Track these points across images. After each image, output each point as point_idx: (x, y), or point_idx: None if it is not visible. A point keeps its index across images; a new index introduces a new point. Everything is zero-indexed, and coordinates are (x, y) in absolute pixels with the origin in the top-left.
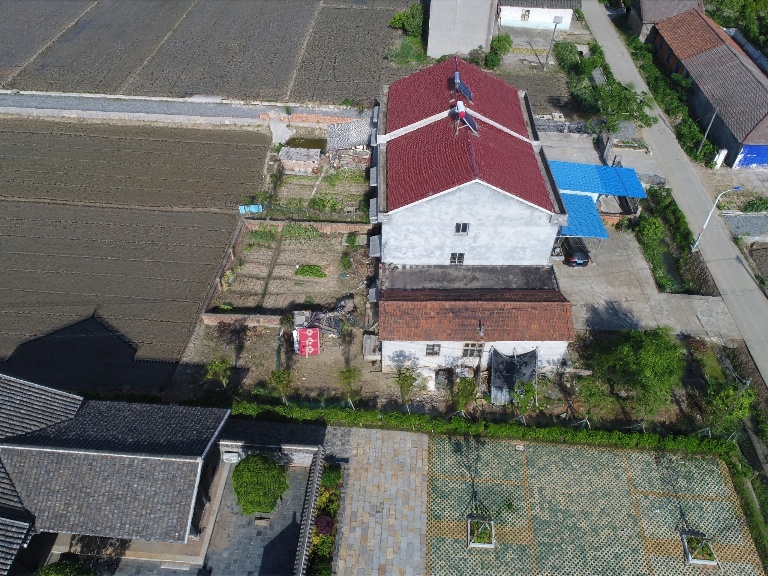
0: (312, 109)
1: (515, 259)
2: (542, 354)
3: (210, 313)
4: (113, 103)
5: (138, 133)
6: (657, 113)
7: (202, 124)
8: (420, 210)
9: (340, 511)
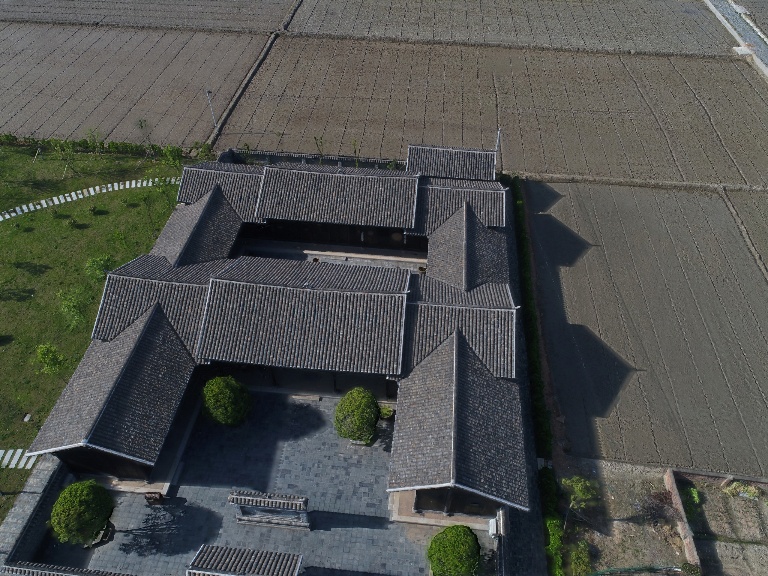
0: None
1: None
2: None
3: None
4: None
5: None
6: None
7: None
8: None
9: None
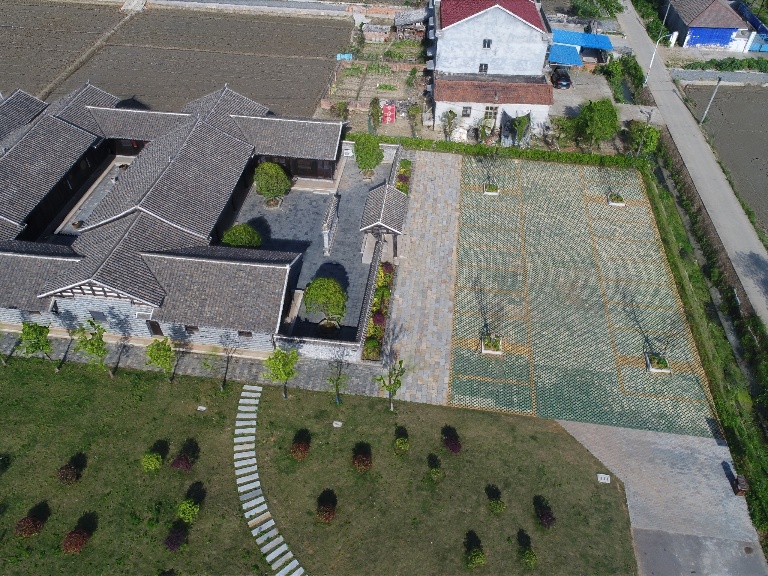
0: (382, 7)
1: (520, 70)
2: (534, 117)
3: (326, 99)
4: (241, 0)
5: (260, 19)
6: (635, 17)
7: (304, 15)
8: (462, 29)
9: (411, 178)
